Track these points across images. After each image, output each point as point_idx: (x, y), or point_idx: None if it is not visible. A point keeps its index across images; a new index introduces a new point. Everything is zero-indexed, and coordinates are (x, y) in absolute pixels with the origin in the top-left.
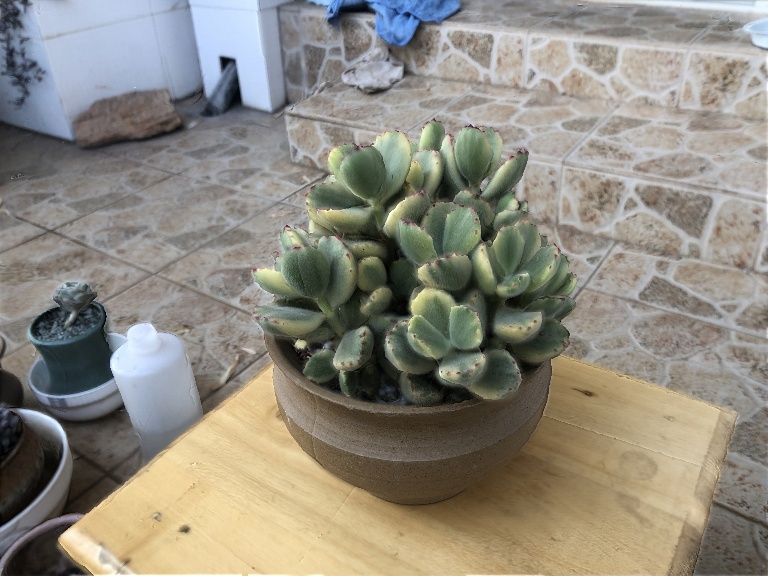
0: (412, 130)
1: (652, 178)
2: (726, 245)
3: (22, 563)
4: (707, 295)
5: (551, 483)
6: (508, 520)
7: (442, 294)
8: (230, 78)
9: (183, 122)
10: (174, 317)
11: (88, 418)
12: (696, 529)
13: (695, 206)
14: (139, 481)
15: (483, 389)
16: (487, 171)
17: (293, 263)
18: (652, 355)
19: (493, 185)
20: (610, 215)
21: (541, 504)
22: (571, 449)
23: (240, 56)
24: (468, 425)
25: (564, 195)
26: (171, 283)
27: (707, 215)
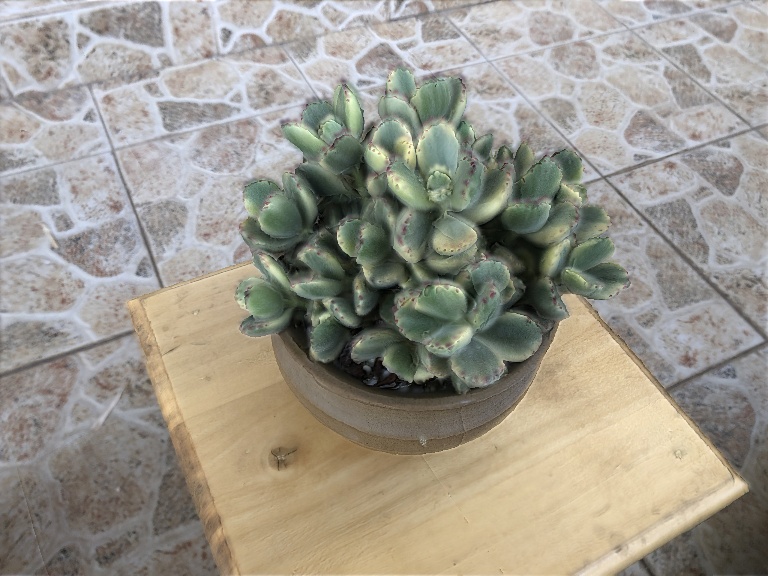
0: None
1: (90, 3)
2: (189, 42)
3: None
4: (211, 96)
5: None
6: None
7: None
8: None
9: None
10: None
11: None
12: None
13: (146, 16)
14: None
15: None
16: None
17: None
18: (230, 174)
19: (454, 125)
20: (67, 61)
21: None
22: None
23: None
24: None
25: (2, 61)
26: None
27: (161, 21)
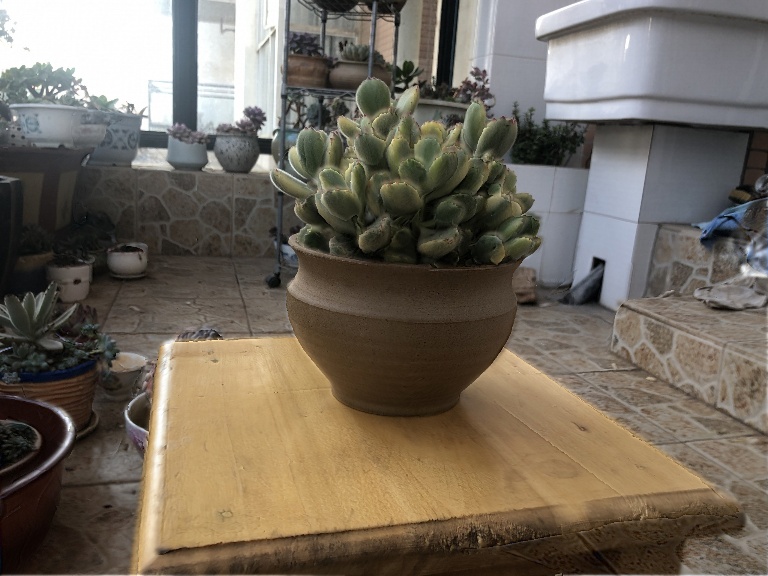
0: (734, 342)
1: None
2: None
3: None
4: None
5: (465, 443)
6: (402, 439)
7: None
8: (596, 277)
9: (538, 300)
10: None
11: None
12: (554, 517)
13: None
14: (223, 341)
15: None
16: None
17: (302, 142)
18: None
19: None
20: None
21: (439, 446)
22: (513, 440)
23: (610, 259)
24: (365, 294)
25: None
26: None
27: None
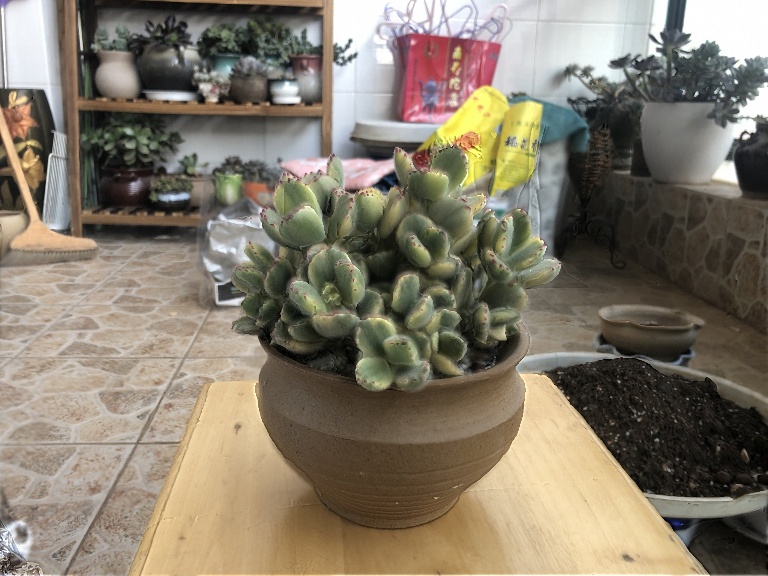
0: None
1: None
2: None
3: None
4: None
5: None
6: None
7: None
8: None
9: None
10: None
11: None
12: None
13: None
14: None
15: None
16: None
17: None
18: None
19: None
20: None
21: None
22: None
23: None
24: None
25: None
26: None
27: None
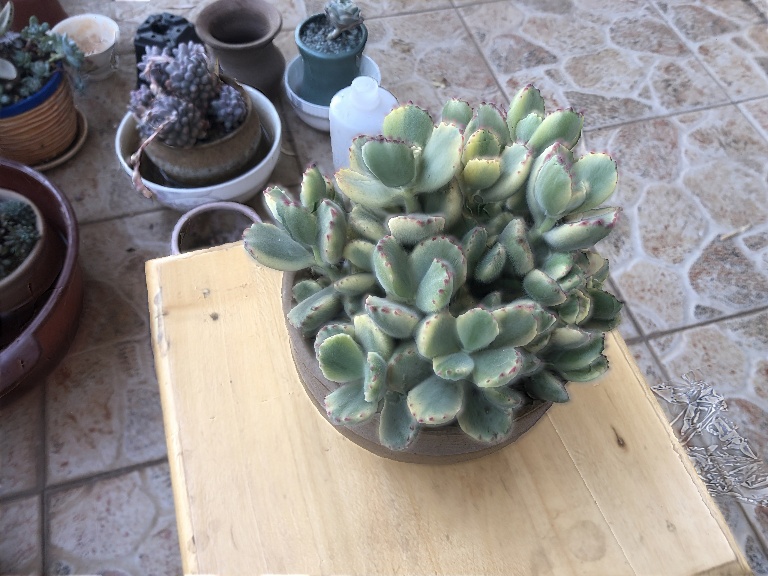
0: None
1: None
2: None
3: (207, 220)
4: None
5: (495, 493)
6: (430, 494)
7: (376, 332)
8: None
9: None
10: (442, 65)
11: (316, 126)
12: None
13: None
14: (216, 255)
15: (381, 424)
16: (571, 211)
17: None
18: None
19: (553, 236)
20: None
21: (469, 503)
22: (545, 479)
23: None
24: None
25: None
26: (463, 26)
27: None
